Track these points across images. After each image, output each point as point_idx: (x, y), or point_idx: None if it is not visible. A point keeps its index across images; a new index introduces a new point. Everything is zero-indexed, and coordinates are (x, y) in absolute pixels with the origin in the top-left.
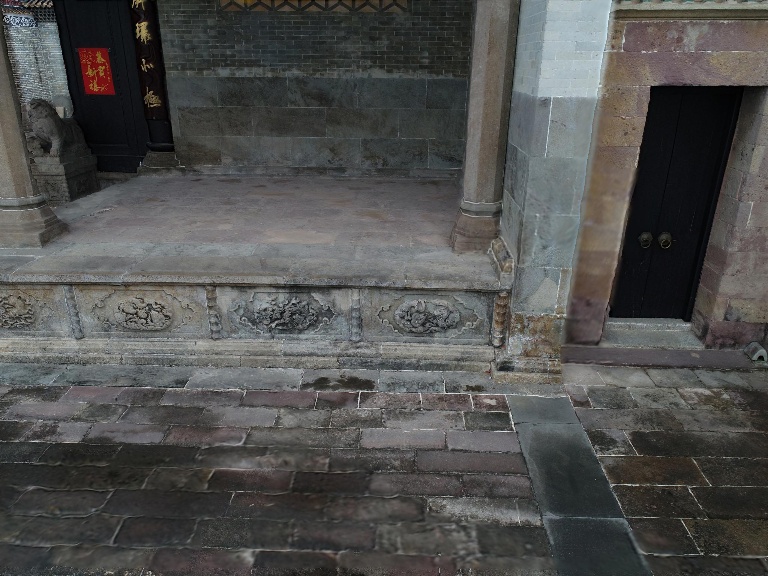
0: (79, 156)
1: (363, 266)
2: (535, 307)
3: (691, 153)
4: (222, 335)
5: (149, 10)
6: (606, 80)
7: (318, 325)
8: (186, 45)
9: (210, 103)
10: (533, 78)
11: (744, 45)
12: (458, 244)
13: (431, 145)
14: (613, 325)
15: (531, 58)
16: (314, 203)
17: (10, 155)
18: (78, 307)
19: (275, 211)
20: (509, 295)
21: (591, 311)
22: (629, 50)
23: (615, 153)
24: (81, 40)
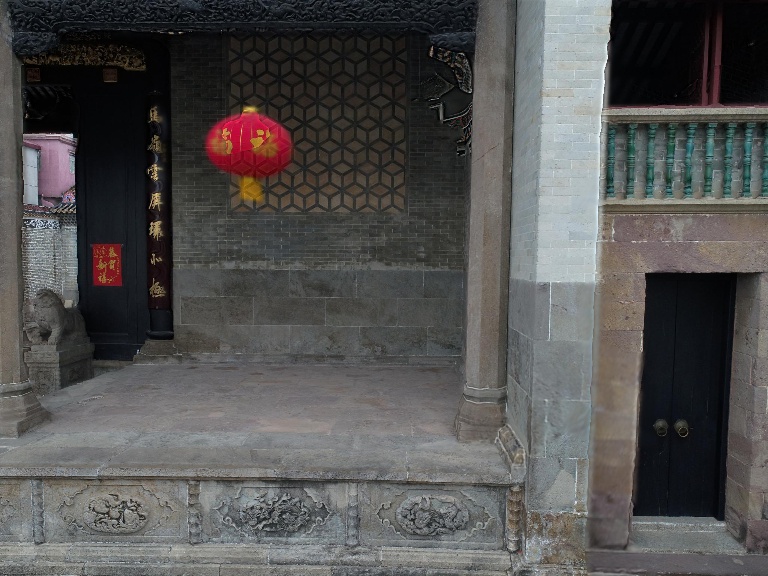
0: (77, 344)
1: (361, 457)
2: (552, 504)
3: (694, 337)
4: (202, 539)
5: (164, 211)
6: (601, 267)
7: (310, 526)
8: (195, 241)
9: (213, 293)
10: (530, 265)
11: (729, 236)
12: (463, 433)
13: (429, 333)
14: (639, 525)
15: (526, 247)
16: (311, 390)
17: (4, 341)
18: (44, 505)
19: (270, 399)
20: (522, 490)
21: (613, 508)
22: (620, 240)
23: (618, 337)
24: (97, 237)
